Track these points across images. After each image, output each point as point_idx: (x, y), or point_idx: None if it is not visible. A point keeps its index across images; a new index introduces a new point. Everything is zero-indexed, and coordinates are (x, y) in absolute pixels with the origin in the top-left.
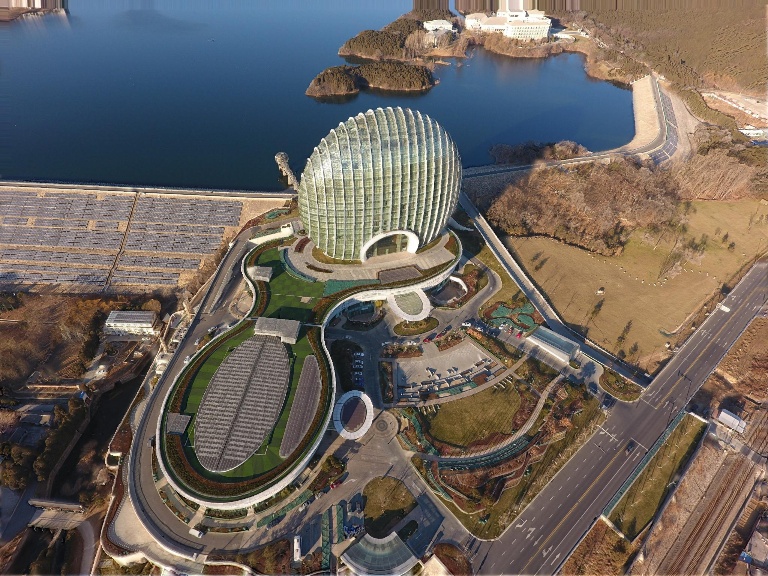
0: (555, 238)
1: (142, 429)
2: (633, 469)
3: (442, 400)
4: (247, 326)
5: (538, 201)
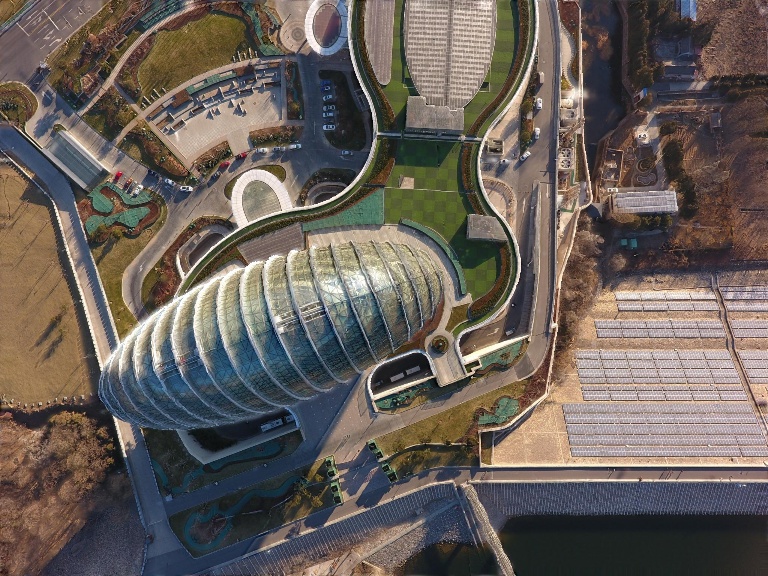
0: (6, 408)
1: (553, 13)
2: (41, 1)
3: (229, 67)
4: (476, 124)
5: (1, 501)
